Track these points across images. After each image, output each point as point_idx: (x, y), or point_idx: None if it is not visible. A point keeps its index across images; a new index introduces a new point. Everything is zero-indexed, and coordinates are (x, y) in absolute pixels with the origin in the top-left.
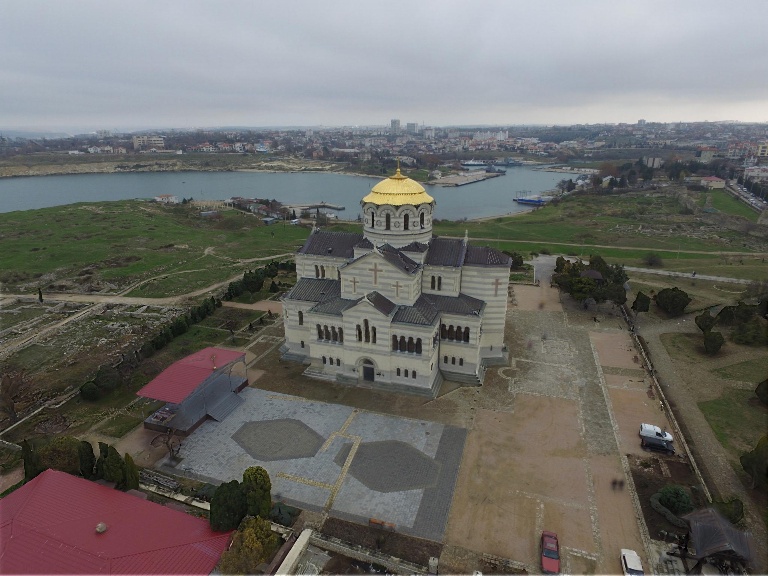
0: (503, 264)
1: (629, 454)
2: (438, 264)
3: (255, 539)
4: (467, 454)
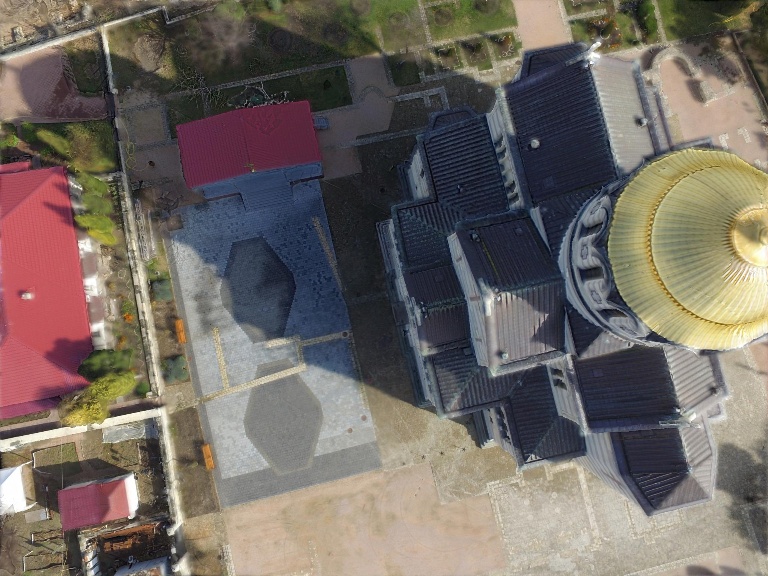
0: (649, 504)
1: None
2: (583, 383)
3: None
4: (340, 484)
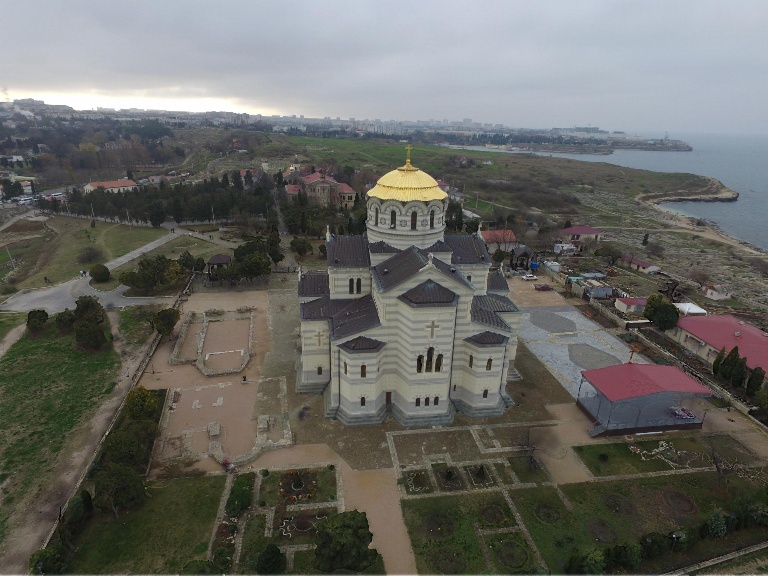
0: None
1: None
2: None
3: None
4: None
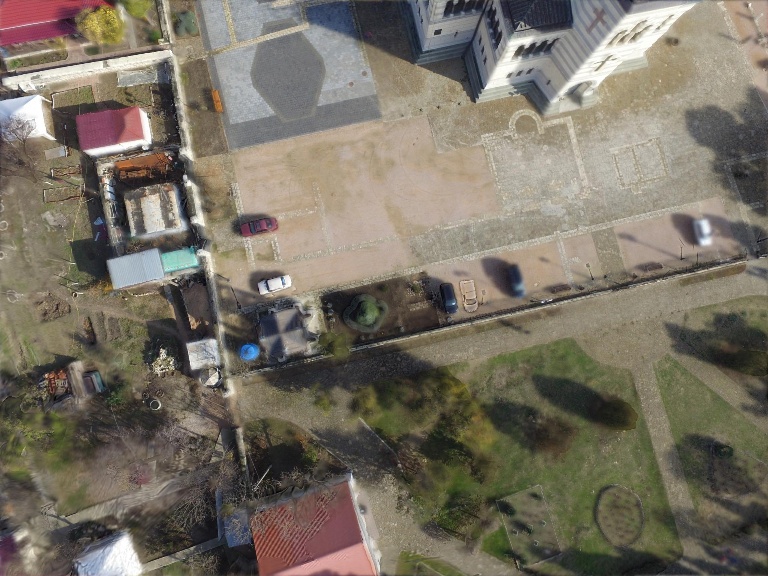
0: None
1: (426, 273)
2: None
3: (96, 25)
4: (342, 132)
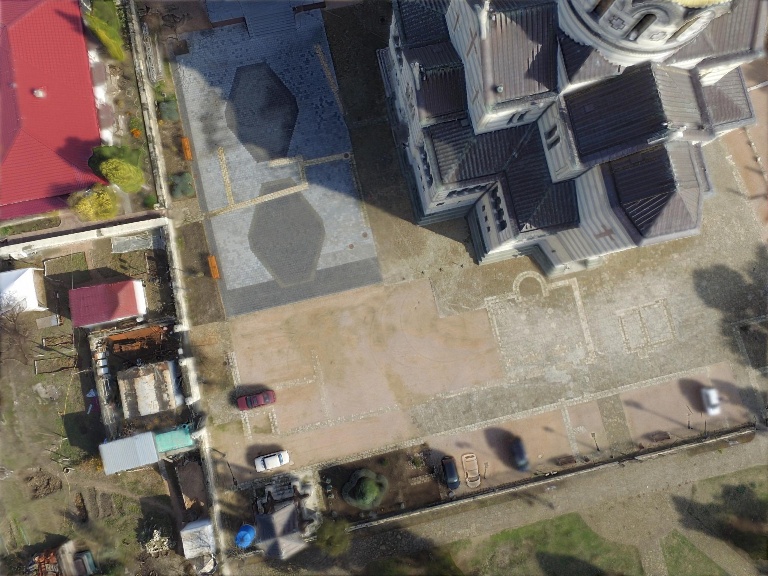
0: (638, 232)
1: (428, 445)
2: (575, 122)
3: (89, 208)
4: (341, 297)
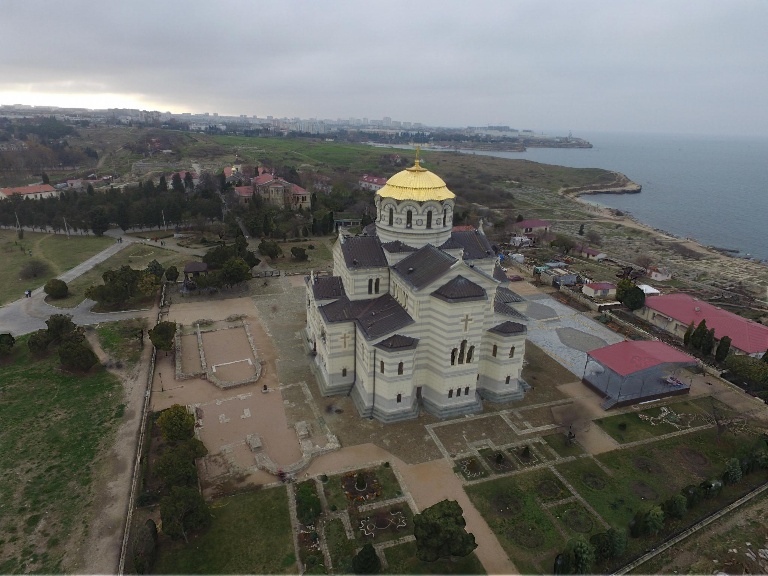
0: None
1: None
2: None
3: None
4: None
